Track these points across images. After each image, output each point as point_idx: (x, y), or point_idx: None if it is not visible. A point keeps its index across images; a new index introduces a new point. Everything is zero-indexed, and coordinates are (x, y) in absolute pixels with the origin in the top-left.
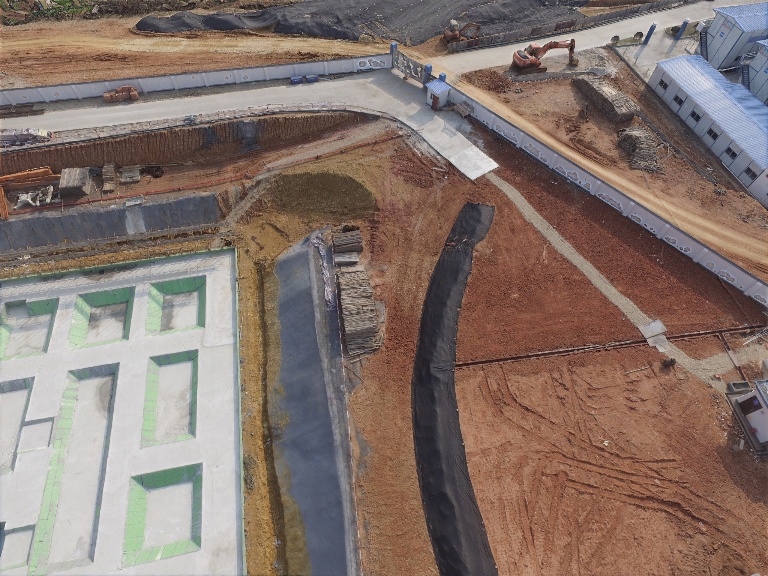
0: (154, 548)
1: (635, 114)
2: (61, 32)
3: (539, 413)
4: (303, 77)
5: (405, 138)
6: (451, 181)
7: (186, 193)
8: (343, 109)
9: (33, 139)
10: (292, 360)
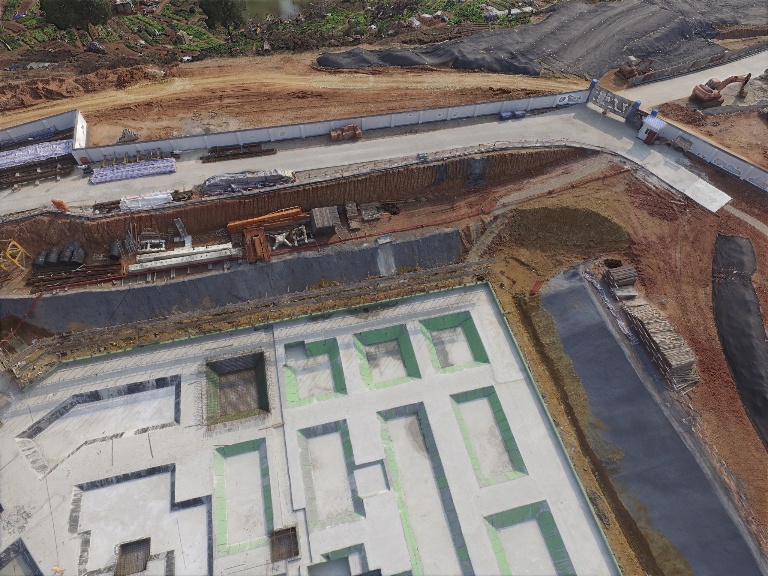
0: None
1: None
2: (245, 69)
3: None
4: None
5: (633, 172)
6: (694, 214)
7: (430, 230)
8: (563, 145)
9: (280, 180)
10: (605, 394)
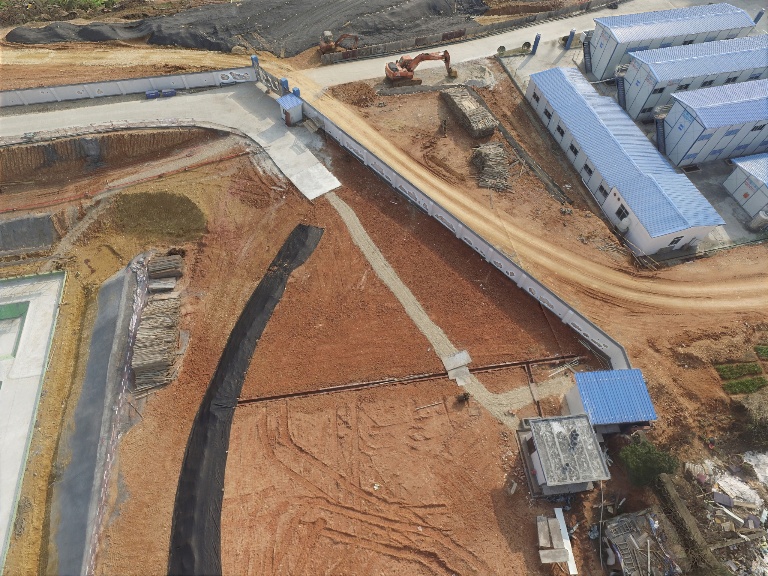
0: None
1: (497, 129)
2: None
3: (313, 454)
4: None
5: (251, 155)
6: (288, 201)
7: (20, 214)
8: (193, 125)
9: None
10: (87, 394)
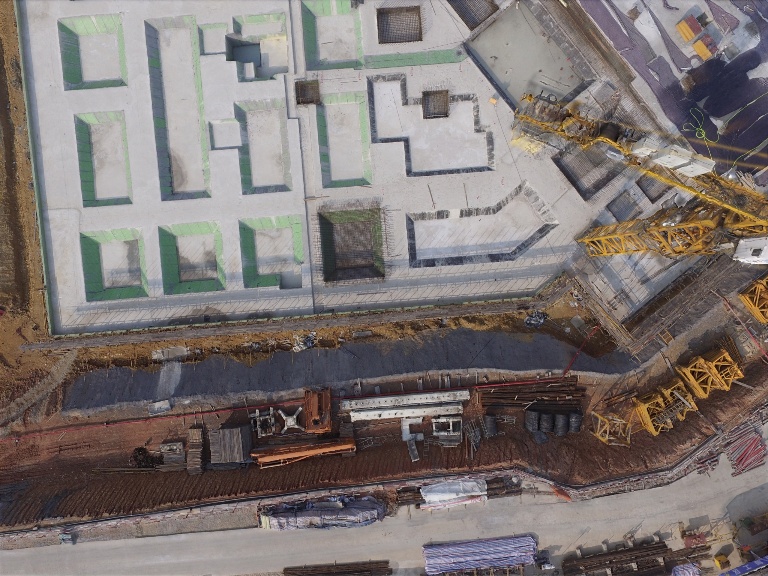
0: (106, 31)
1: None
2: None
3: None
4: None
5: None
6: None
7: (99, 417)
8: None
9: None
10: None
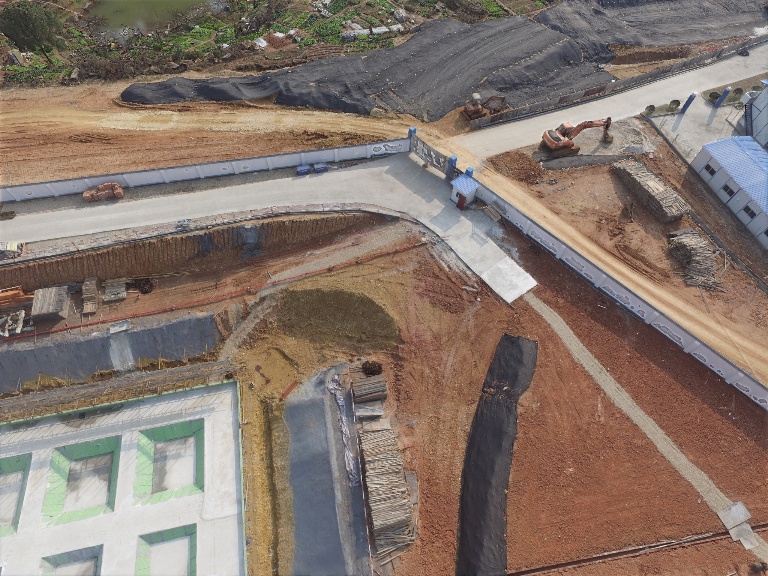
0: None
1: None
2: (36, 104)
3: None
4: (310, 165)
5: (429, 247)
6: (485, 304)
7: (179, 314)
8: (357, 209)
9: (1, 254)
10: (309, 549)
